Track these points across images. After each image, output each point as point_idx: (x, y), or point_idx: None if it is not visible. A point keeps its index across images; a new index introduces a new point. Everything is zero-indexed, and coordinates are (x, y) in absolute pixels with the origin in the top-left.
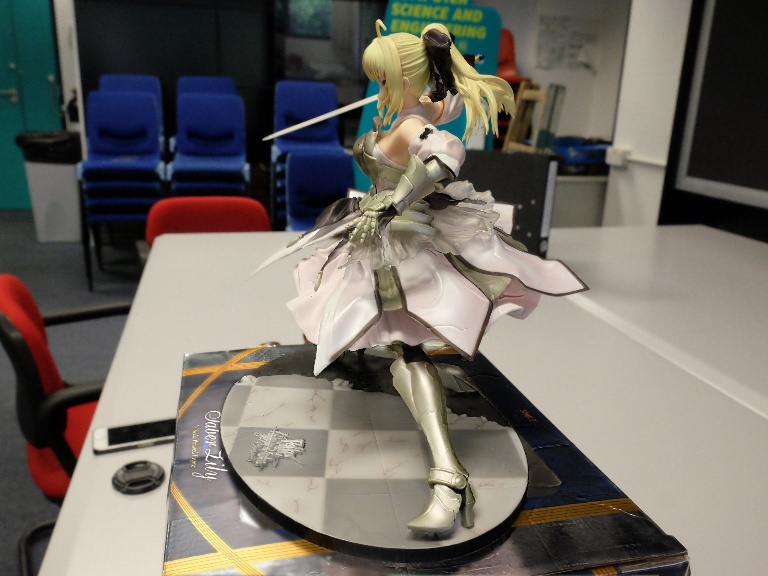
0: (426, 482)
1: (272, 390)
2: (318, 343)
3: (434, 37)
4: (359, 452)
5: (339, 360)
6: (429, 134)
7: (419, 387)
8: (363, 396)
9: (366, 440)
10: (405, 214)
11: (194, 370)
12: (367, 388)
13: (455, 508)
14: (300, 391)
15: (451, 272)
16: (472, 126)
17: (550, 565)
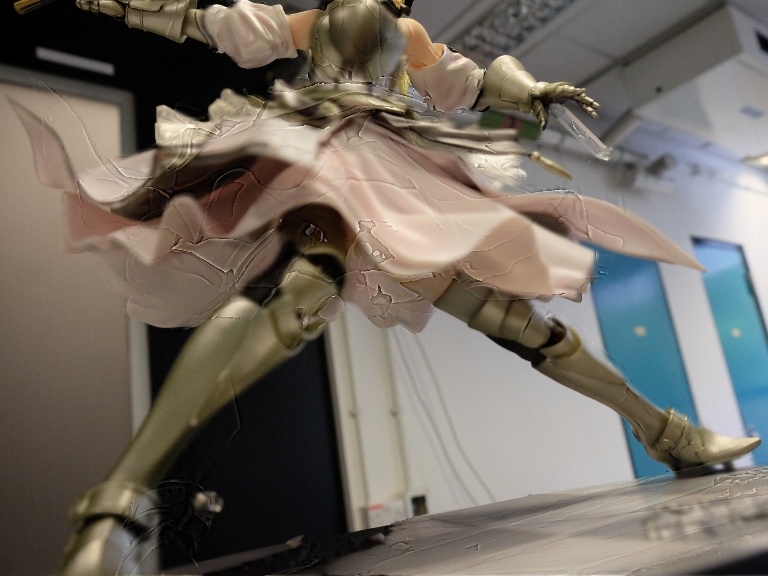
0: None
1: (550, 562)
2: None
3: None
4: None
5: None
6: None
7: None
8: None
9: None
10: None
11: None
12: None
13: None
14: None
15: None
16: None
17: None
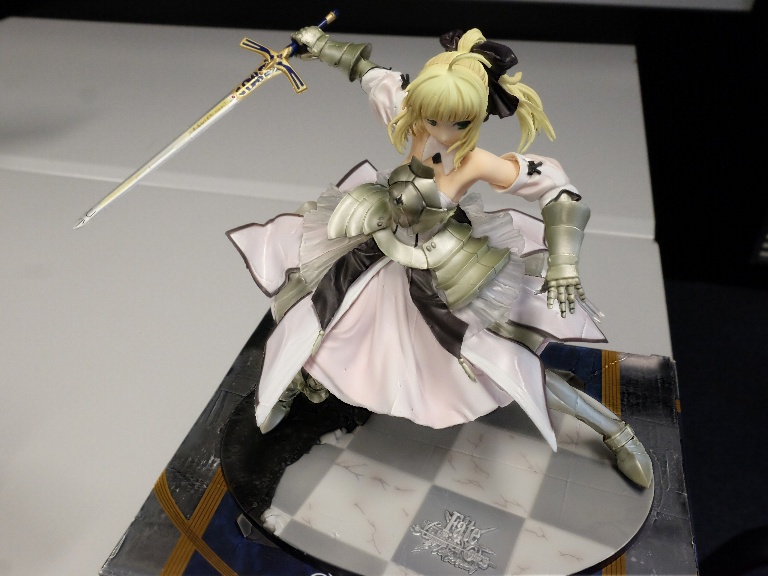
0: (559, 450)
1: (315, 503)
2: (537, 425)
3: (493, 51)
4: (489, 476)
5: (286, 418)
6: (539, 168)
7: (558, 389)
8: (374, 430)
9: (468, 462)
10: (483, 250)
11: (168, 572)
12: (359, 421)
13: (643, 448)
14: (332, 478)
15: (528, 279)
16: (527, 135)
17: (672, 429)
